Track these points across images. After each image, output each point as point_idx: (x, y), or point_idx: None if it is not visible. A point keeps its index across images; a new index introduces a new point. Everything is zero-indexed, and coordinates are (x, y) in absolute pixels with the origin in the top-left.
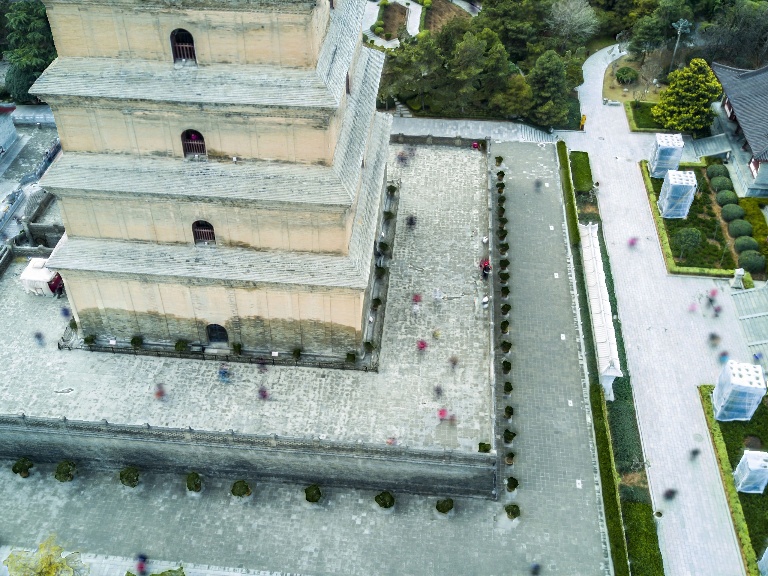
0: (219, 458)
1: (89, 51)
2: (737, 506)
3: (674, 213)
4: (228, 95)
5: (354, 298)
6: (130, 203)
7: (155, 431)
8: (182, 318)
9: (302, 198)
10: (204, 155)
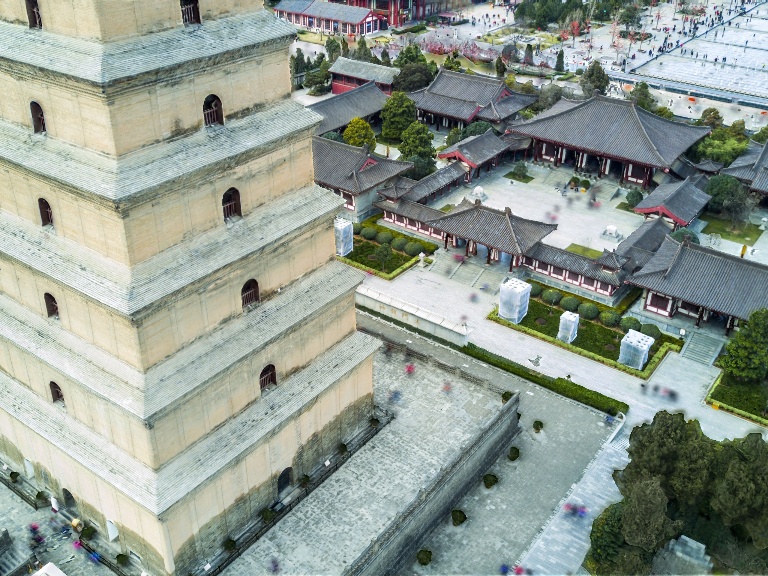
0: (393, 552)
1: (159, 247)
2: (579, 349)
3: (347, 250)
4: (281, 228)
5: (370, 363)
6: (214, 387)
7: (355, 567)
8: (261, 484)
9: (338, 292)
10: (253, 302)
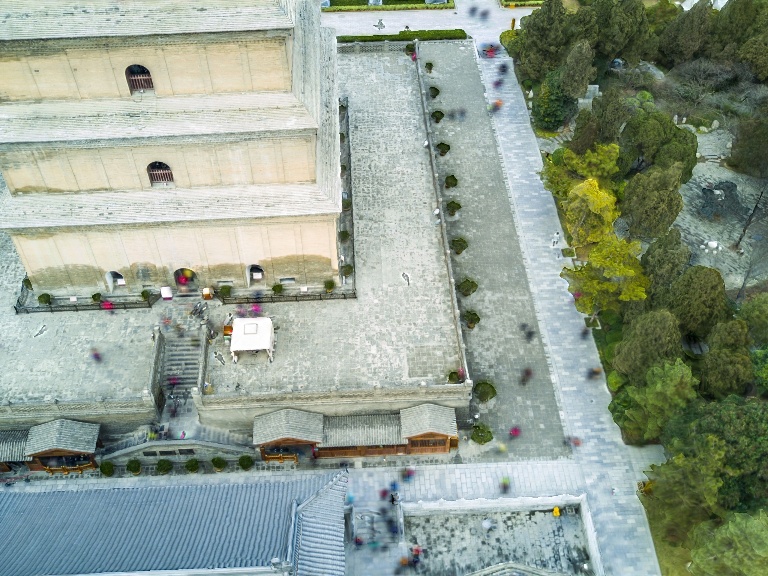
0: None
1: None
2: (392, 6)
3: None
4: None
5: None
6: None
7: None
8: None
9: None
10: None
